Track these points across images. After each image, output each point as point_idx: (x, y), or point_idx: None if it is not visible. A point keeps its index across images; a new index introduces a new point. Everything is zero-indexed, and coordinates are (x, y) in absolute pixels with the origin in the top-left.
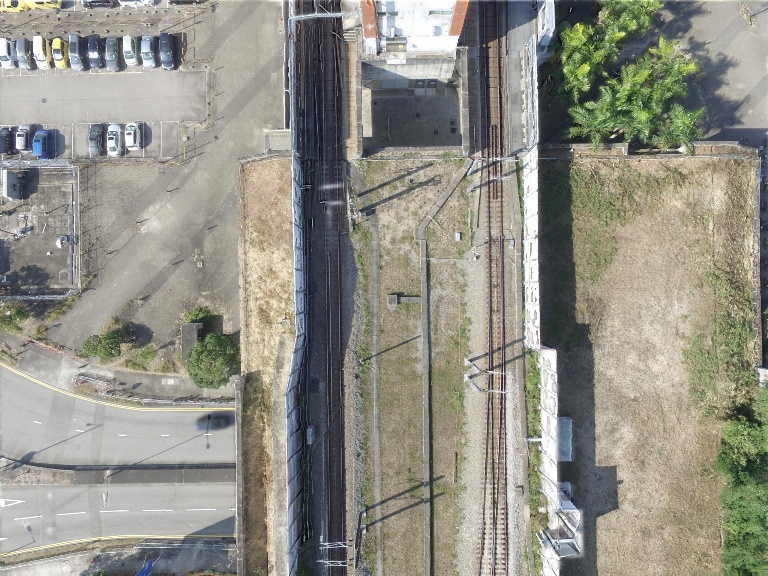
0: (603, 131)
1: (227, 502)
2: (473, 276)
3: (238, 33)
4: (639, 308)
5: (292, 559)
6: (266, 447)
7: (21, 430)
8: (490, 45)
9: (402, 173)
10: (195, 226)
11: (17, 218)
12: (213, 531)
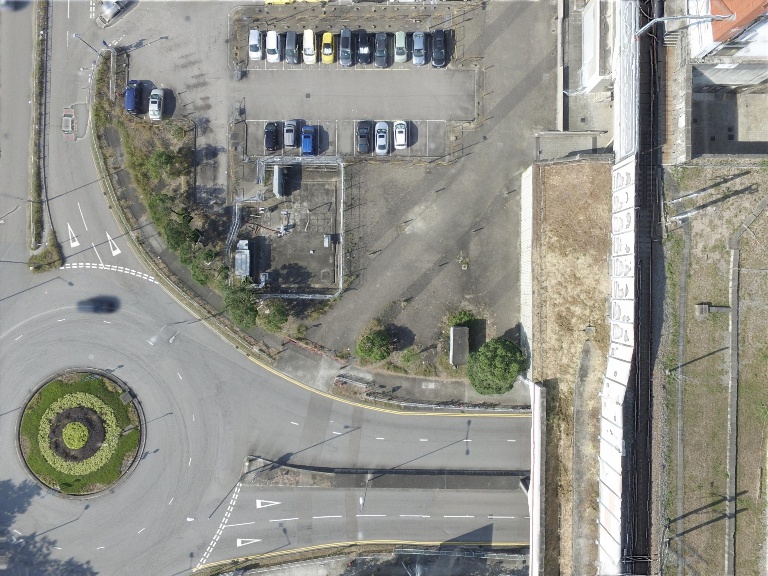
0: None
1: (486, 509)
2: None
3: (509, 32)
4: None
5: (592, 572)
6: (561, 456)
7: (278, 431)
8: None
9: (718, 180)
10: (461, 228)
11: (279, 215)
12: (472, 539)
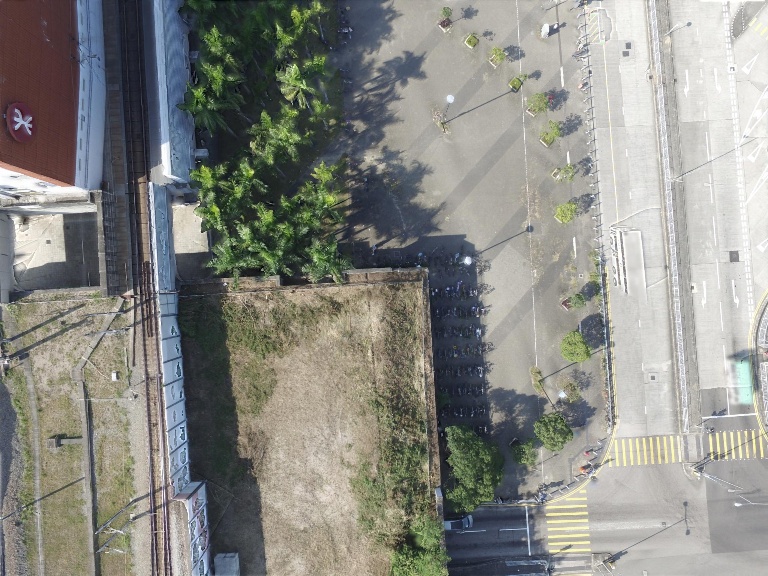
0: (249, 266)
1: None
2: (134, 415)
3: None
4: (303, 439)
5: None
6: None
7: None
8: (140, 181)
9: (54, 315)
10: None
11: None
12: None
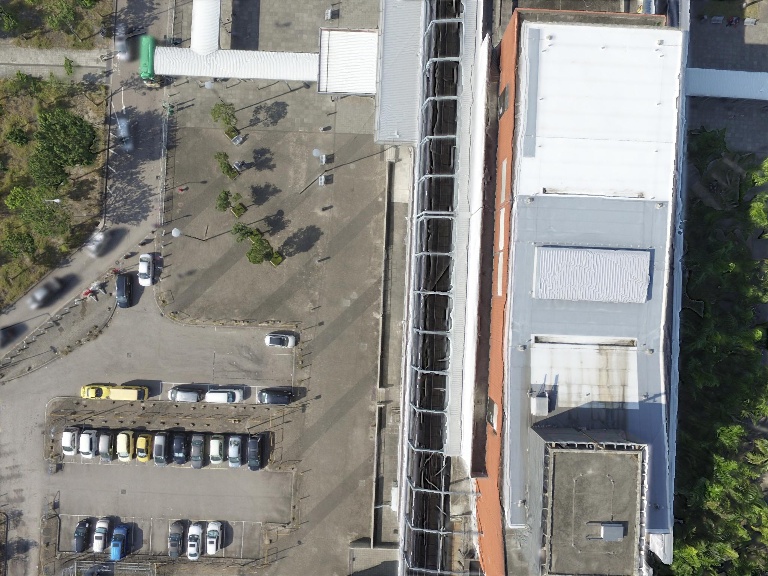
0: None
1: None
2: None
3: (328, 436)
4: None
5: None
6: None
7: None
8: None
9: None
10: None
11: None
12: None
